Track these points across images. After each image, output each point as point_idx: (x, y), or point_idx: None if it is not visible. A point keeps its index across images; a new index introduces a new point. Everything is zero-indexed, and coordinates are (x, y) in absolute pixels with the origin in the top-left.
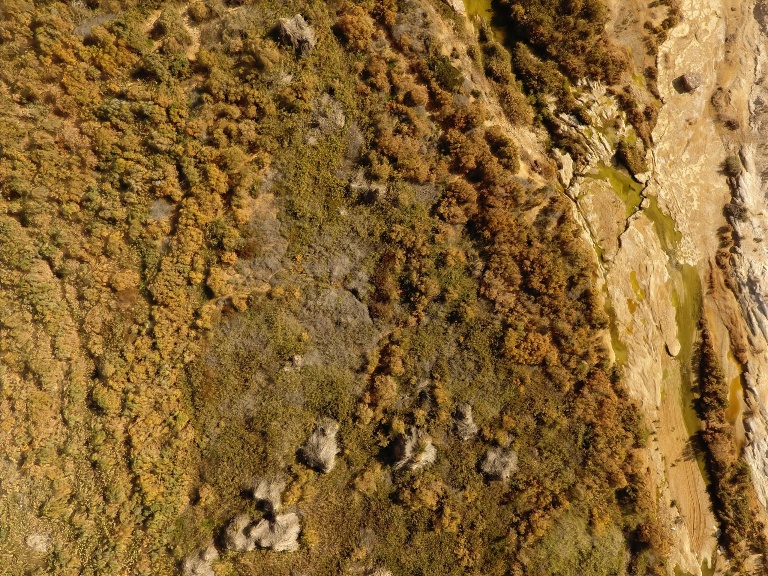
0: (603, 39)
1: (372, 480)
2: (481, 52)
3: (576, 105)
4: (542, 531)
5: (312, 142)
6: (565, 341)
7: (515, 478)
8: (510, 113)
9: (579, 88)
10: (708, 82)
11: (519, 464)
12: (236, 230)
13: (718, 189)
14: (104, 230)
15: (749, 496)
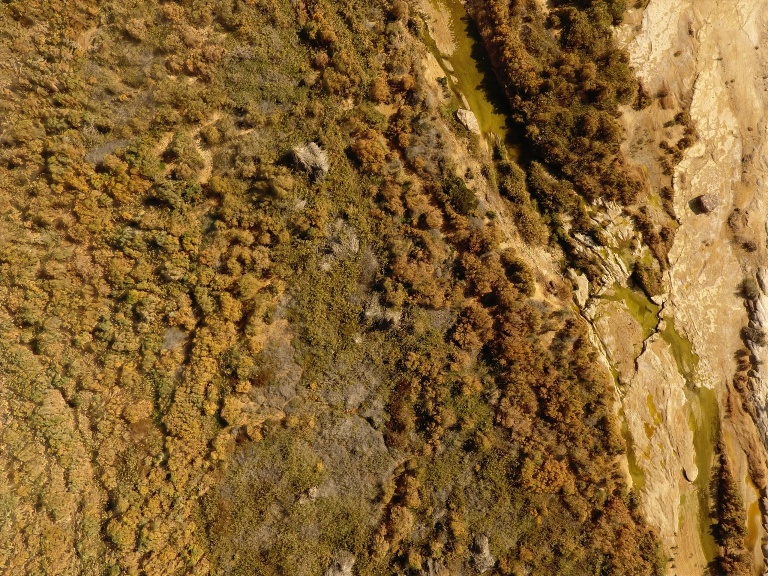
0: (619, 160)
1: None
2: (495, 170)
3: (592, 226)
4: None
5: (326, 268)
6: (582, 469)
7: None
8: (525, 233)
9: (594, 207)
10: (725, 203)
11: None
12: (250, 358)
13: (735, 312)
14: (117, 361)
15: None
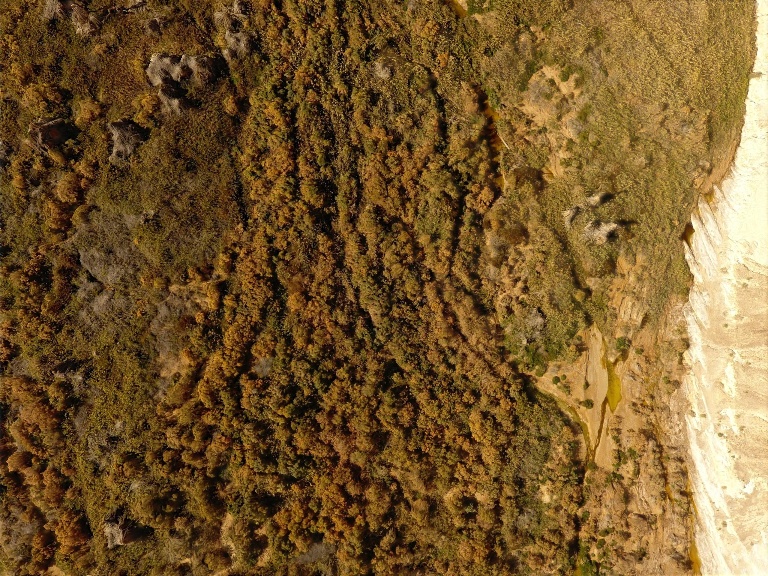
0: None
1: (83, 111)
2: None
3: None
4: None
5: (119, 423)
6: None
7: None
8: None
9: None
10: None
11: None
12: None
13: None
14: (311, 350)
15: None
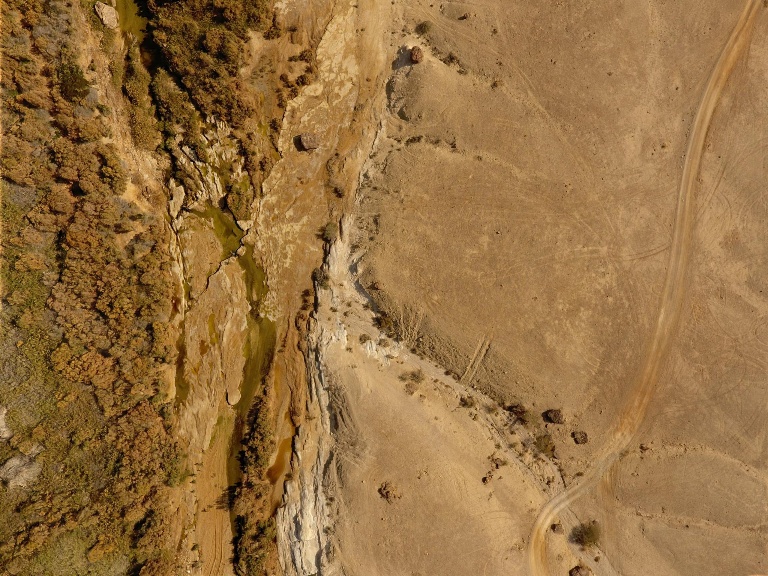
0: (236, 82)
1: None
2: (125, 70)
3: (198, 141)
4: (36, 545)
5: None
6: None
7: None
8: (135, 135)
9: (209, 125)
10: (328, 146)
11: (38, 476)
12: None
13: (312, 252)
14: None
15: (269, 556)
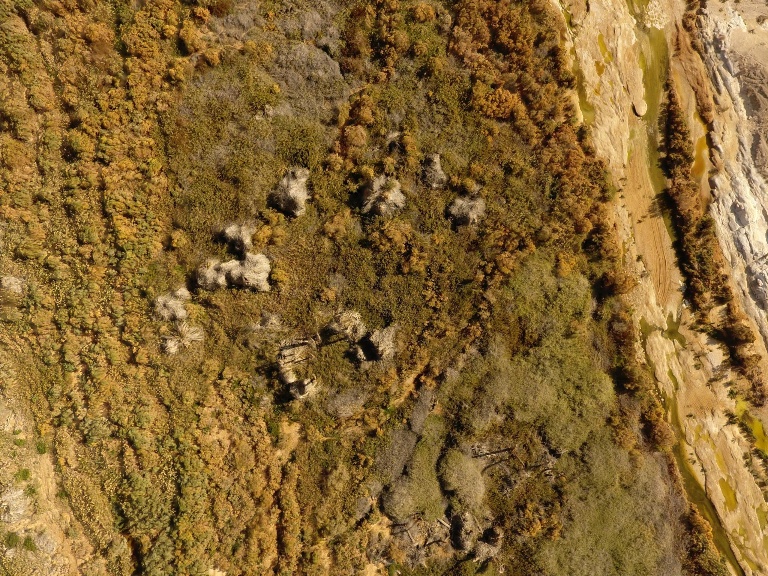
0: None
1: (342, 223)
2: None
3: None
4: (508, 270)
5: None
6: (533, 96)
7: (483, 225)
8: None
9: None
10: None
11: (486, 210)
12: None
13: None
14: None
15: (714, 250)
